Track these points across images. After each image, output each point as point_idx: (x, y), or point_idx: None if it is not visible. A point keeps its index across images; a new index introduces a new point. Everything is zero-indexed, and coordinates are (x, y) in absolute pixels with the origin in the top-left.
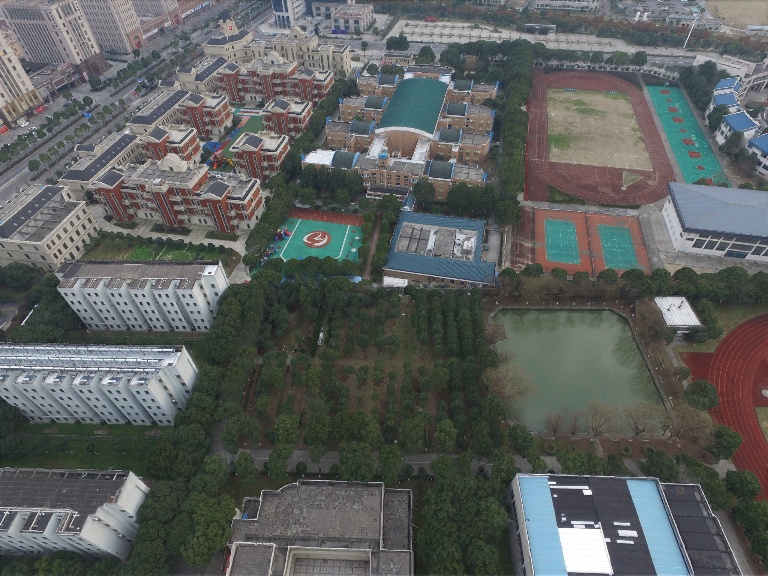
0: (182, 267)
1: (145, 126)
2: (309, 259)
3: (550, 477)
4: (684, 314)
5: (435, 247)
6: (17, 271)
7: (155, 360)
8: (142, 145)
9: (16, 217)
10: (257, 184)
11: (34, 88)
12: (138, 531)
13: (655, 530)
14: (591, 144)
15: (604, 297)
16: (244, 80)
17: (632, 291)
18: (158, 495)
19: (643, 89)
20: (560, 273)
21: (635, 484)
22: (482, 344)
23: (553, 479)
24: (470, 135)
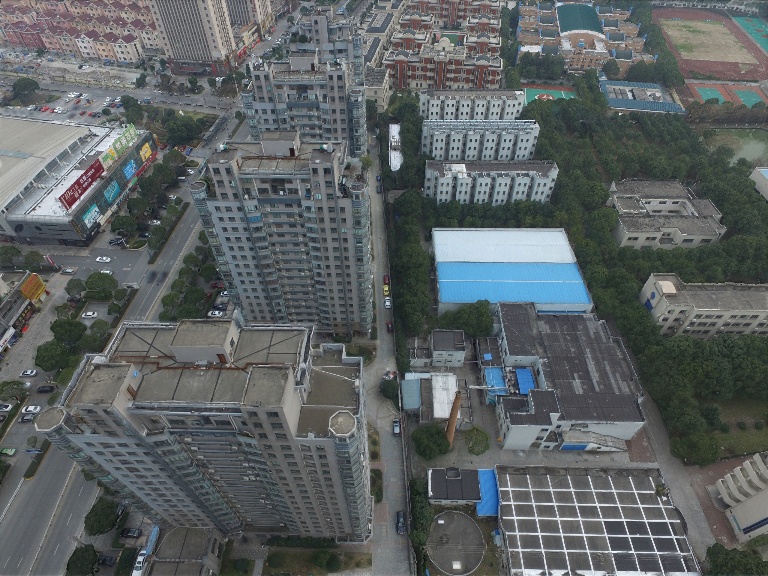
0: (500, 92)
1: (379, 34)
2: (561, 99)
3: None
4: None
5: (636, 96)
6: (372, 104)
7: None
8: (394, 42)
9: None
10: None
11: (271, 12)
12: (561, 191)
13: None
14: (708, 49)
15: (756, 120)
16: (433, 7)
17: None
18: (563, 178)
19: (731, 19)
20: (730, 103)
21: None
22: (696, 135)
23: None
24: (629, 38)
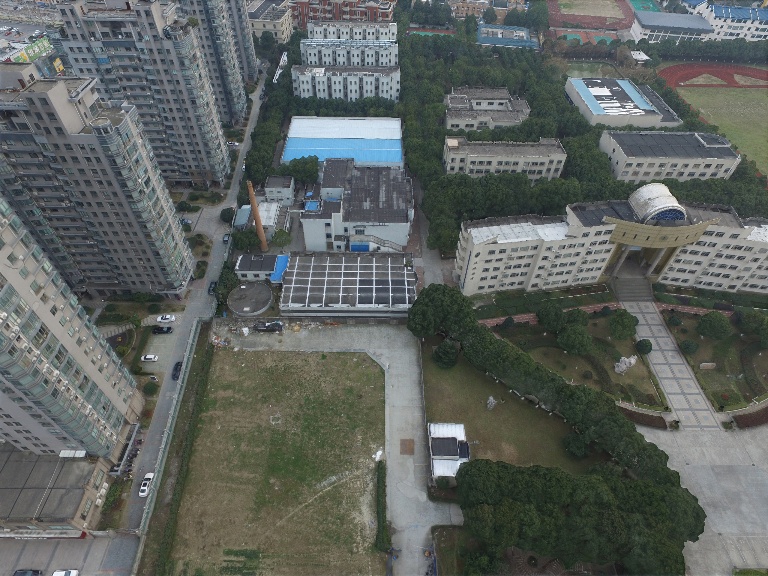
0: (377, 23)
1: None
2: None
3: (583, 79)
4: (642, 56)
5: (504, 35)
6: (269, 35)
7: (389, 42)
8: None
9: (258, 10)
10: (392, 5)
11: None
12: (404, 92)
13: (628, 89)
14: (586, 7)
15: (600, 55)
16: None
17: (614, 52)
18: None
19: None
20: (576, 40)
21: (619, 81)
22: (540, 61)
23: (584, 79)
24: None
